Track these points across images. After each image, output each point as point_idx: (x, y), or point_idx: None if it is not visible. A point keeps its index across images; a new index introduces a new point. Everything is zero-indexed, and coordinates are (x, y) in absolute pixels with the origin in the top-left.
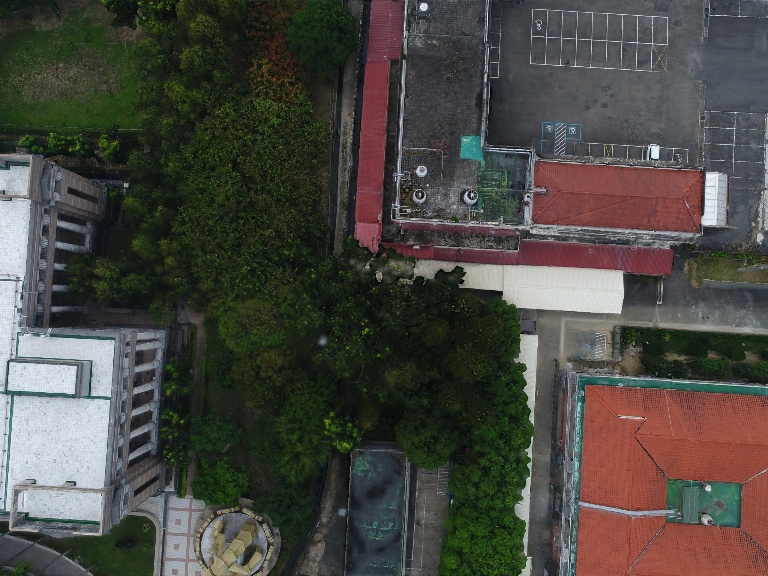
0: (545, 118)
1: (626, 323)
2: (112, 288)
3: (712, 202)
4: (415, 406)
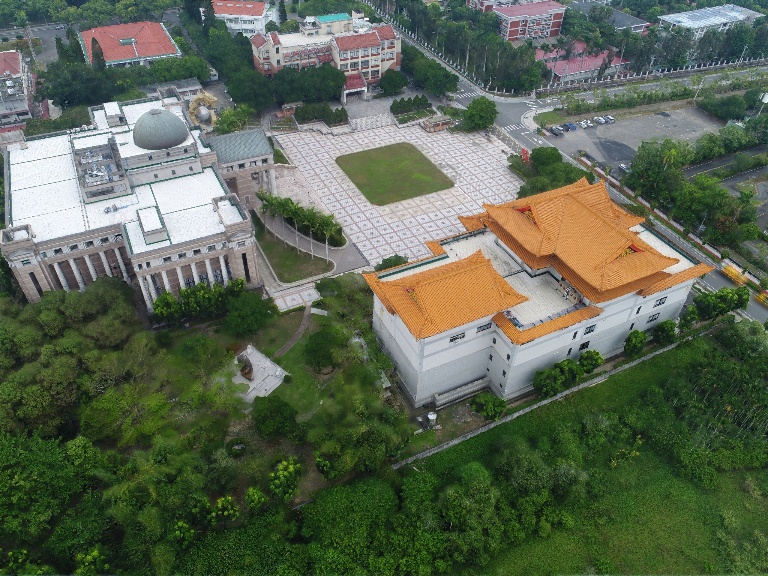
0: None
1: None
2: None
3: None
4: None
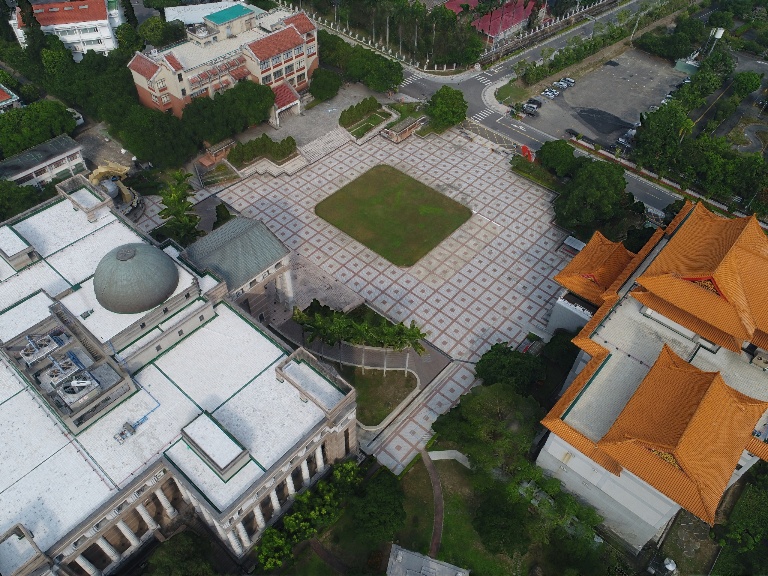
0: None
1: None
2: None
3: None
4: None
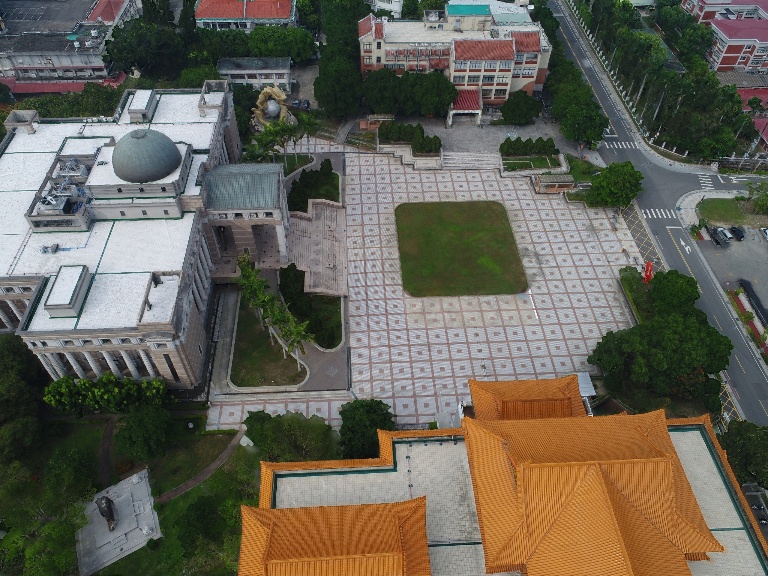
0: None
1: None
2: None
3: None
4: None
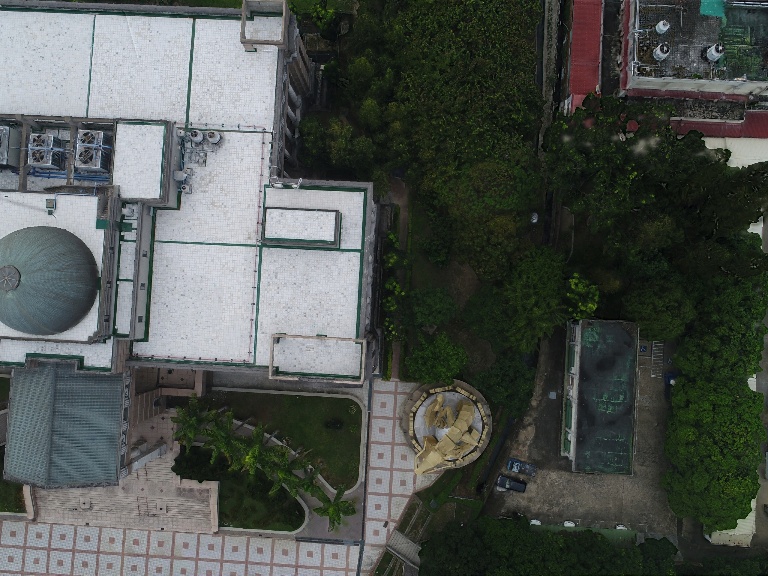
0: None
1: None
2: (344, 149)
3: None
4: (652, 272)
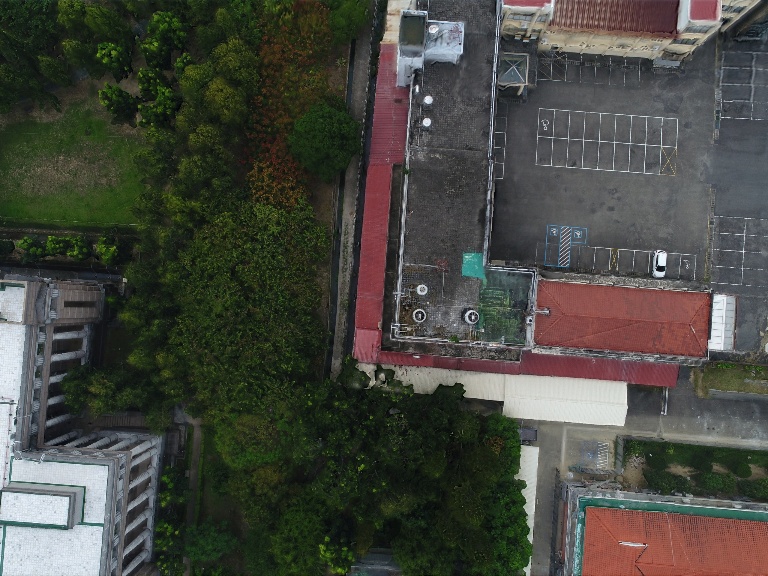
0: (550, 221)
1: (629, 433)
2: (107, 404)
3: (719, 326)
4: (412, 526)
